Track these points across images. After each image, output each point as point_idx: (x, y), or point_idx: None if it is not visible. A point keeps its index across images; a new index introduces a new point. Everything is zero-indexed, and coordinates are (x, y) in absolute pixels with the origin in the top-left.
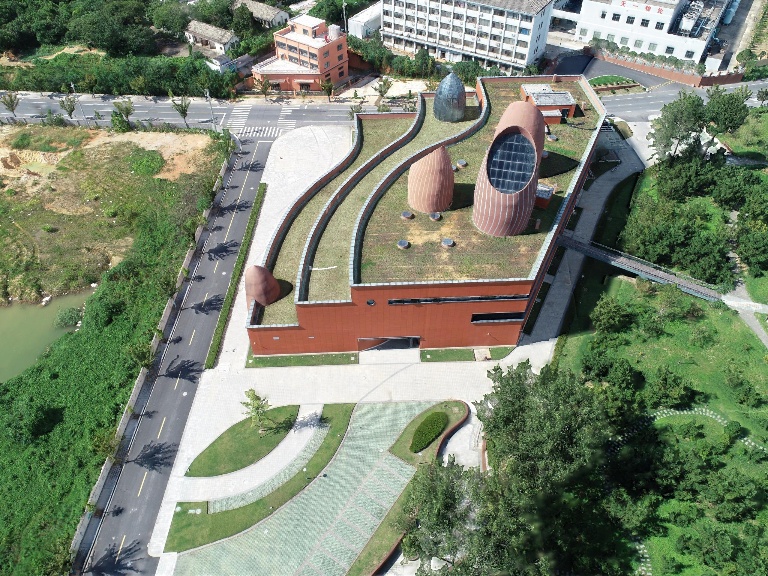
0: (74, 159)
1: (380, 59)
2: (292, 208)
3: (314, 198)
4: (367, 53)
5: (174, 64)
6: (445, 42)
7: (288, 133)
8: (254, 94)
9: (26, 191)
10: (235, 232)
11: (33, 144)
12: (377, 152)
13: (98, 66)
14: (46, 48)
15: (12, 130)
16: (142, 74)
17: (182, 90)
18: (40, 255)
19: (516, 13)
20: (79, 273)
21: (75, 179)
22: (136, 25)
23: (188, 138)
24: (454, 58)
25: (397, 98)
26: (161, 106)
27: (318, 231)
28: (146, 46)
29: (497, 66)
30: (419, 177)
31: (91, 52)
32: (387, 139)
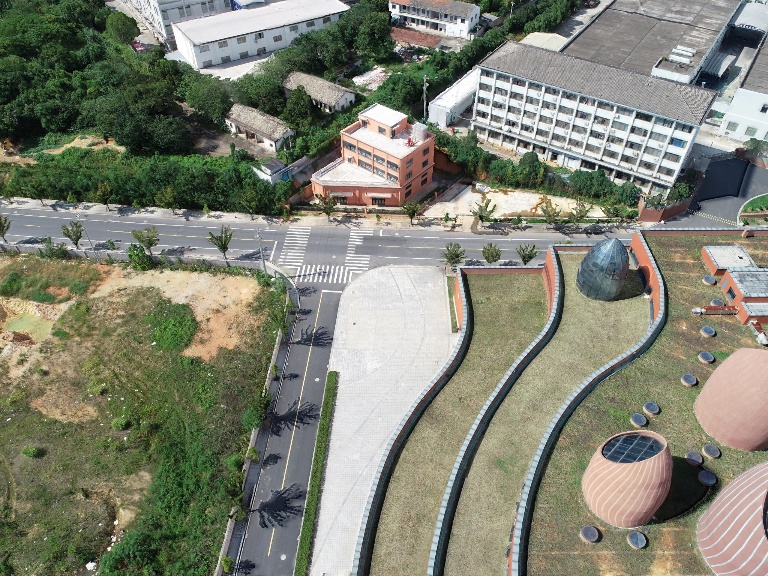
0: (77, 317)
1: (474, 163)
2: (387, 458)
3: (415, 430)
4: (456, 152)
5: (212, 171)
6: (560, 143)
7: (361, 277)
8: (313, 210)
9: (8, 374)
10: (297, 468)
11: (24, 290)
12: (511, 366)
13: (115, 167)
14: (52, 138)
15: (0, 263)
16: (170, 183)
17: (221, 204)
18: (16, 504)
19: (669, 120)
20: (69, 549)
21: (76, 354)
22: (165, 116)
23: (228, 283)
24: (569, 162)
25: (499, 221)
26: (193, 226)
27: (440, 540)
28: (177, 142)
29: (630, 179)
30: (620, 488)
31: (107, 146)
32: (507, 313)
